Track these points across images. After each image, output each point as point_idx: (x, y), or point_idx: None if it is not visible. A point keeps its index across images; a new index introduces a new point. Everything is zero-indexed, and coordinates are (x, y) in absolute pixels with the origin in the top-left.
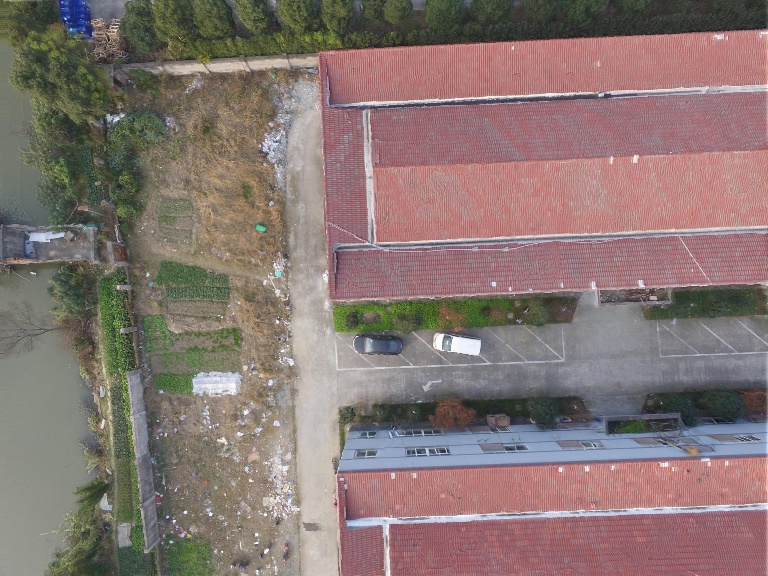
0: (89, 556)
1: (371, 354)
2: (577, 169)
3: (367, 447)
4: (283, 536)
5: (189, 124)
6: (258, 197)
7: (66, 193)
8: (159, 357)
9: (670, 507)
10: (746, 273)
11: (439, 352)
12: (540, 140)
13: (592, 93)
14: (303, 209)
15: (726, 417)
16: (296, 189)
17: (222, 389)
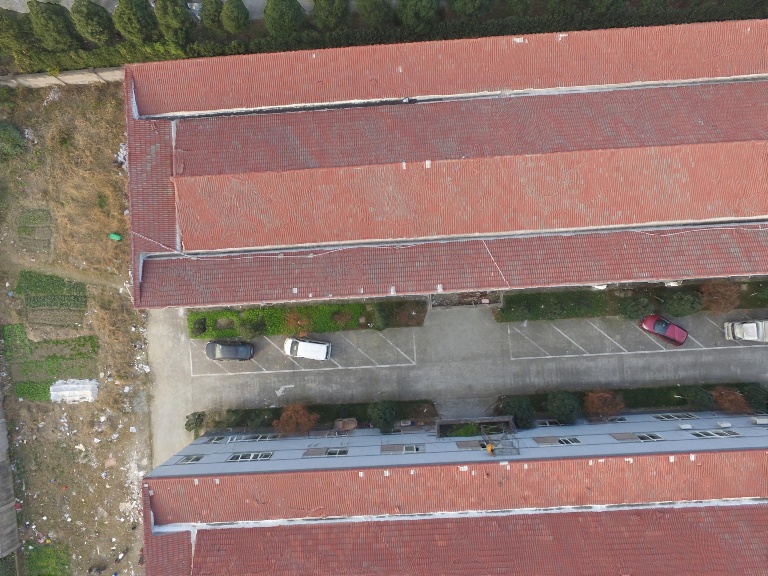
0: None
1: (222, 360)
2: (375, 175)
3: (198, 453)
4: (140, 541)
5: (48, 135)
6: (114, 206)
7: None
8: (19, 365)
9: (474, 511)
10: (545, 276)
11: (292, 357)
12: (329, 147)
13: (397, 99)
14: None
15: (561, 419)
16: None
17: (79, 396)
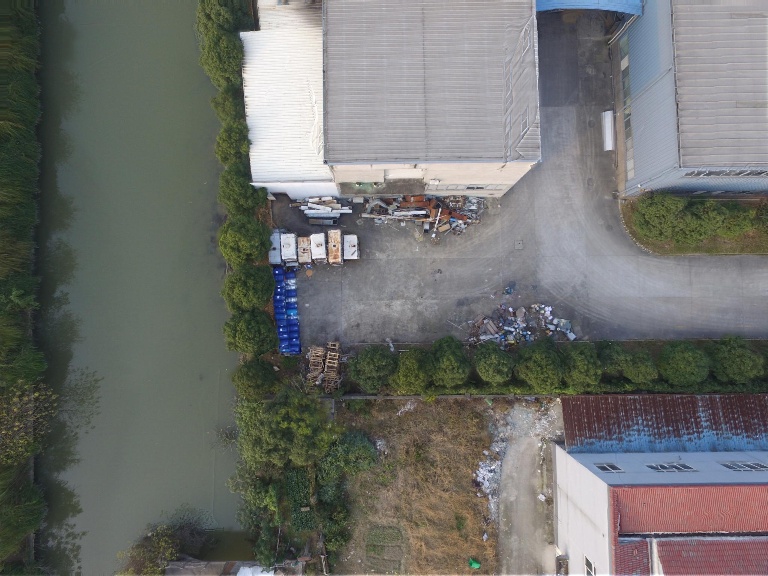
0: None
1: None
2: None
3: None
4: None
5: (399, 447)
6: (471, 529)
7: (268, 515)
8: None
9: None
10: None
11: None
12: None
13: None
14: (516, 542)
15: None
16: (509, 520)
17: None
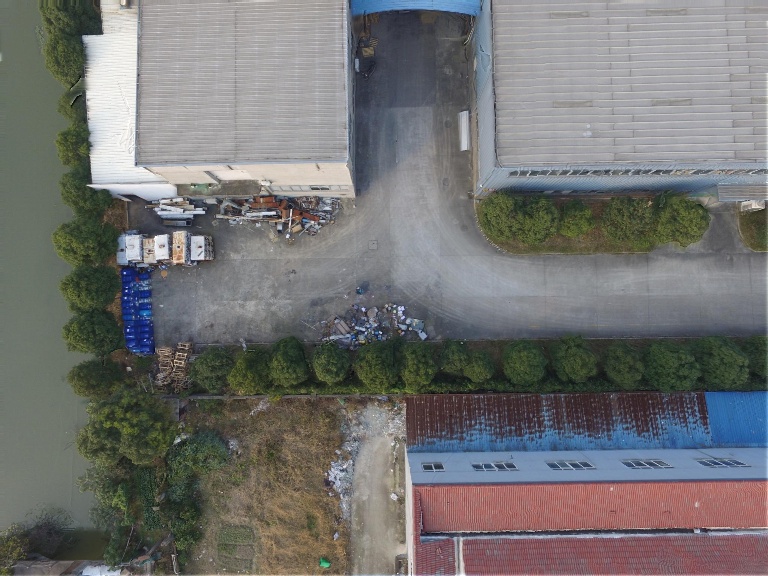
0: None
1: None
2: None
3: None
4: None
5: (252, 446)
6: (322, 528)
7: (121, 515)
8: None
9: None
10: None
11: None
12: None
13: (687, 528)
14: (368, 541)
15: None
16: (361, 519)
17: None
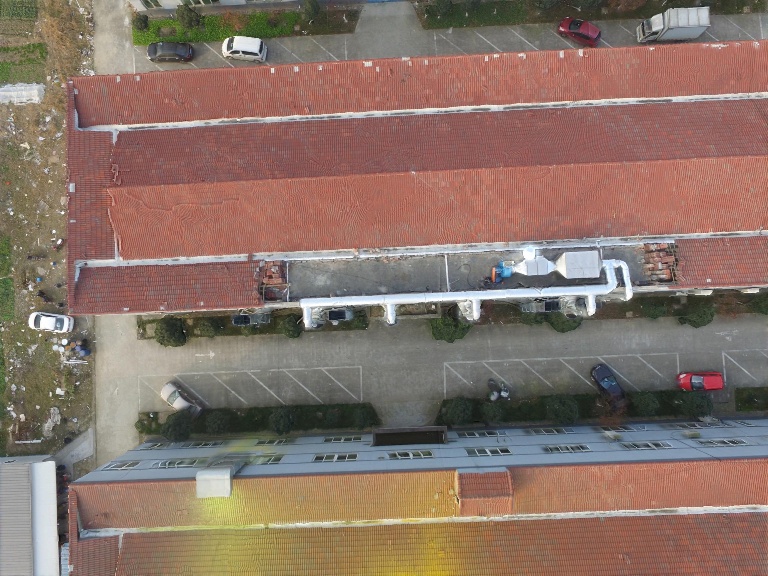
0: None
1: (162, 58)
2: None
3: None
4: None
5: None
6: None
7: None
8: None
9: (379, 111)
10: None
11: (230, 62)
12: None
13: None
14: None
15: None
16: None
17: (26, 97)
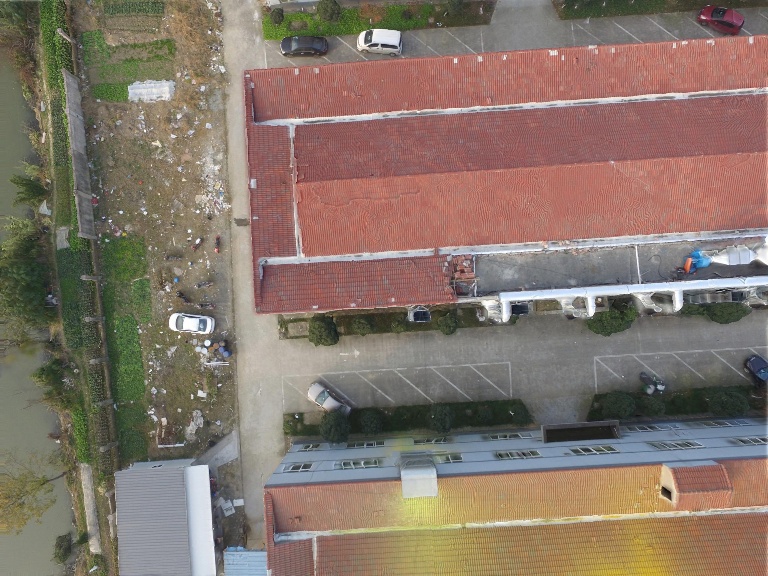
0: (26, 249)
1: (297, 53)
2: None
3: None
4: (215, 232)
5: None
6: None
7: None
8: (97, 69)
9: (563, 100)
10: None
11: (364, 55)
12: None
13: None
14: None
15: None
16: None
17: (156, 95)
